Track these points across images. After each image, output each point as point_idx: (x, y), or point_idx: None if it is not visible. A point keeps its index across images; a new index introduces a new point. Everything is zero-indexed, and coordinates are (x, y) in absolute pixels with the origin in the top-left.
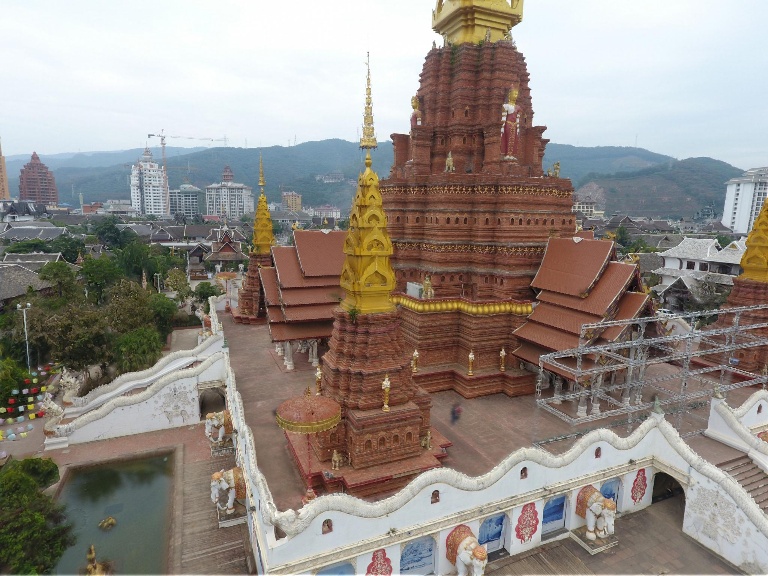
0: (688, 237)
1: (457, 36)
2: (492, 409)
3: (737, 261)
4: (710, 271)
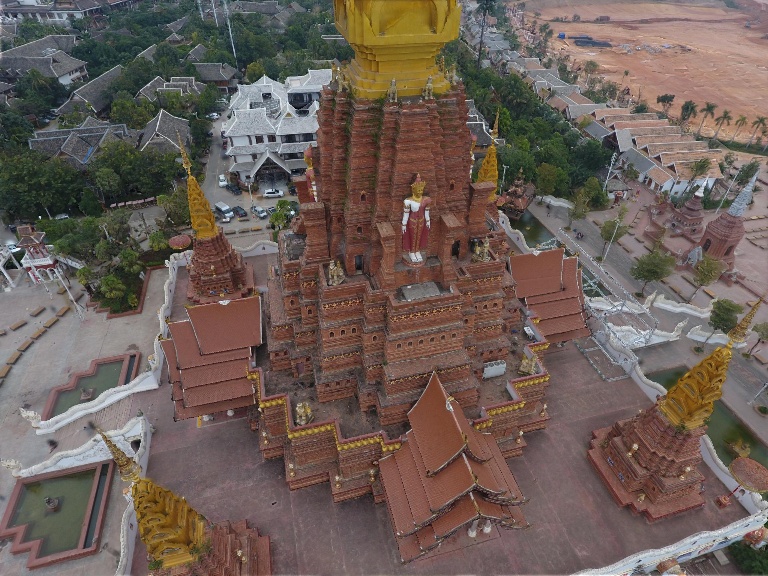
0: (45, 43)
1: (412, 68)
2: (559, 385)
3: (305, 131)
4: (283, 142)
